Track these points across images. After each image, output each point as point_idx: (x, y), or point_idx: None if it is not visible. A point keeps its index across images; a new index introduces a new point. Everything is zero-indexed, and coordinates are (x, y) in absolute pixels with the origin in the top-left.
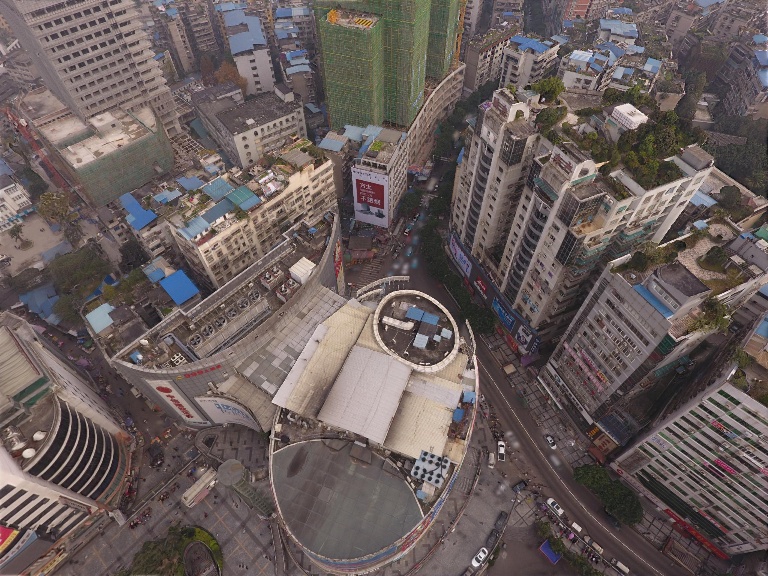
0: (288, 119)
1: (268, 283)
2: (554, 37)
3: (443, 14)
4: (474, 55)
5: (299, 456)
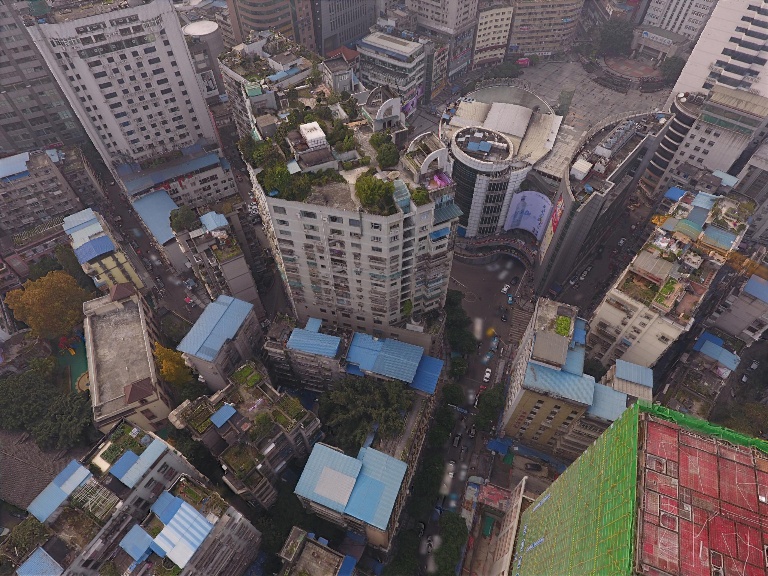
0: None
1: (603, 157)
2: None
3: None
4: None
5: (536, 111)
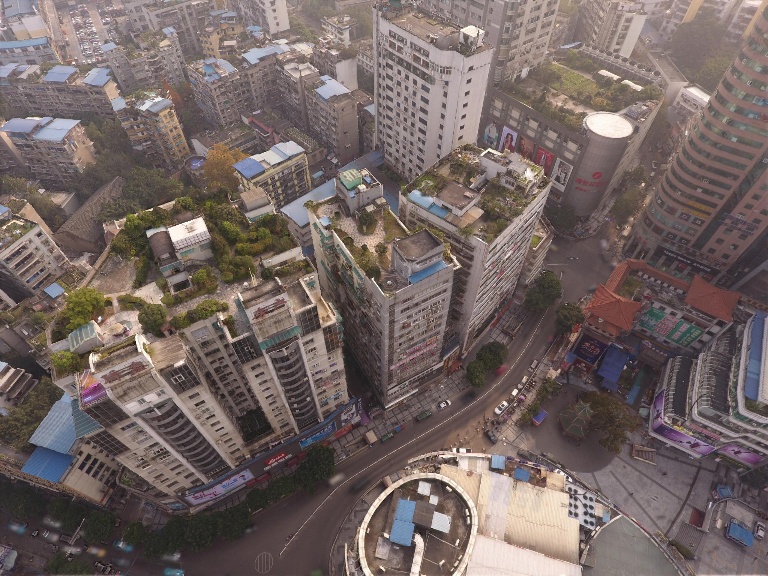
0: None
1: None
2: None
3: None
4: None
5: None
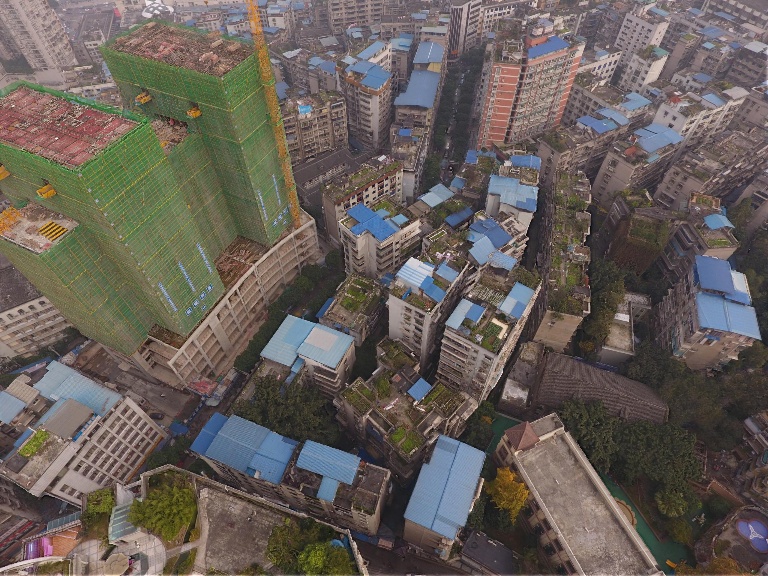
0: (44, 301)
1: None
2: (436, 188)
3: (244, 179)
4: (330, 205)
5: None
